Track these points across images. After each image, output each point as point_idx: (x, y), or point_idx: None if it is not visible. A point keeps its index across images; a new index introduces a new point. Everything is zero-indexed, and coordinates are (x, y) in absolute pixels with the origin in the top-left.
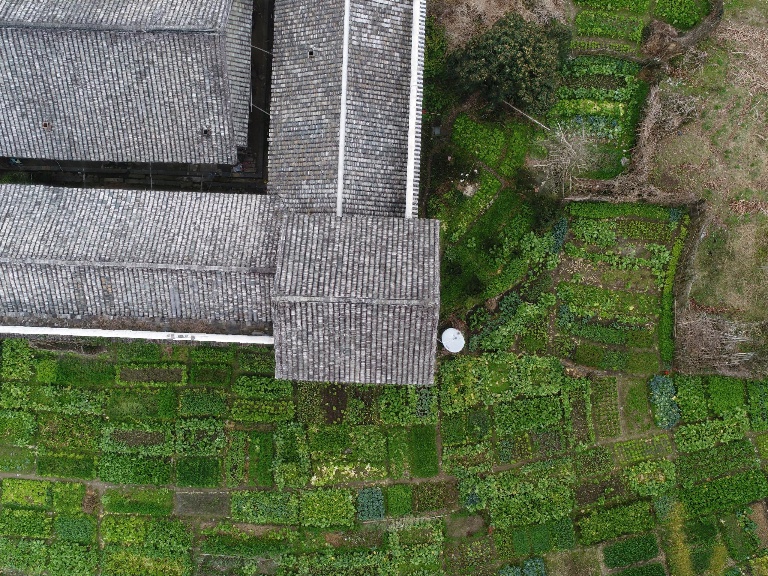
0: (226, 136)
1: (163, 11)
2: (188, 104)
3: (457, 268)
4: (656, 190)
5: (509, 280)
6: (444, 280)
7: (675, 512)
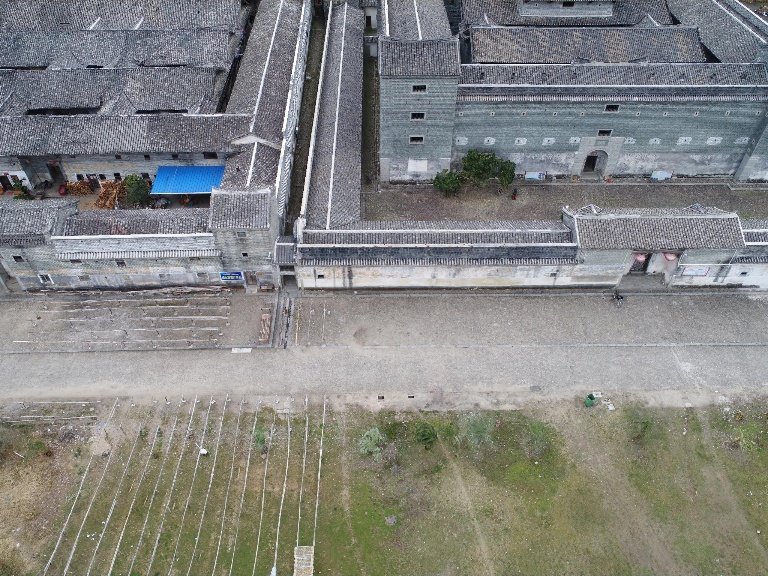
0: None
1: (28, 5)
2: None
3: None
4: None
5: None
6: None
7: None
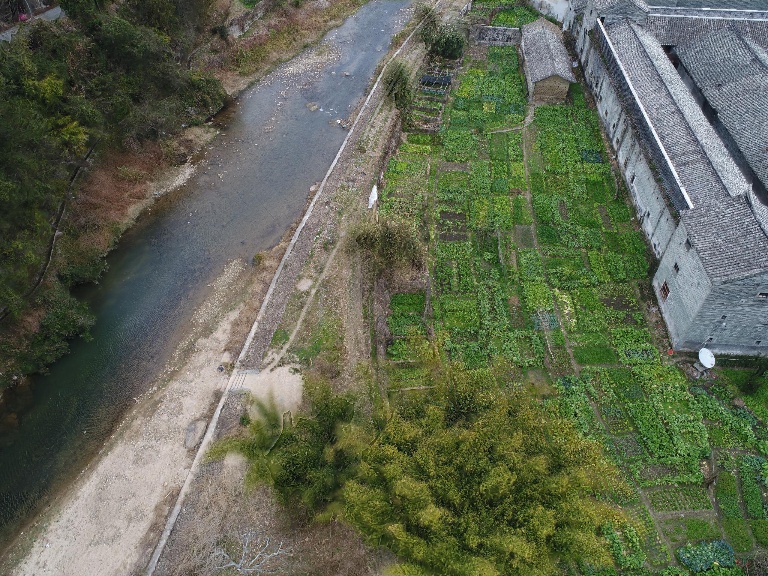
0: None
1: None
2: None
3: (766, 364)
4: None
5: (767, 416)
6: (742, 372)
7: (590, 567)
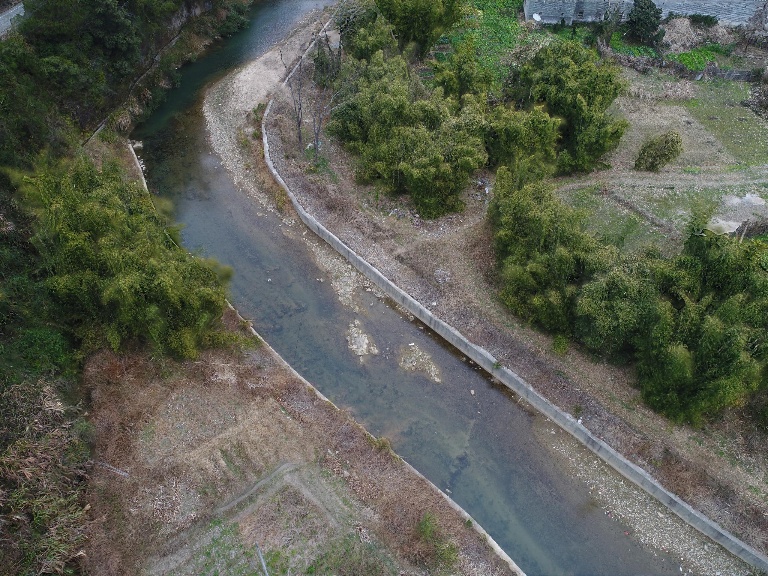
0: None
1: None
2: None
3: None
4: (609, 50)
5: None
6: None
7: None
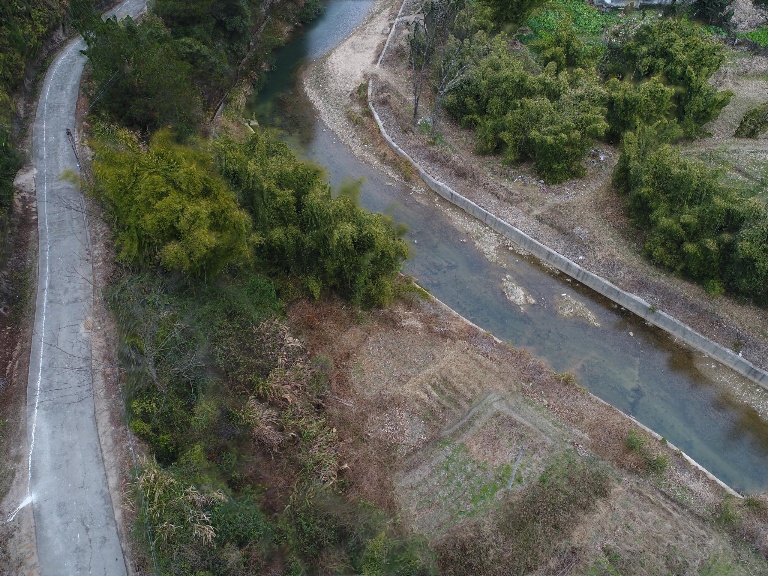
0: None
1: None
2: None
3: (633, 2)
4: None
5: None
6: None
7: None
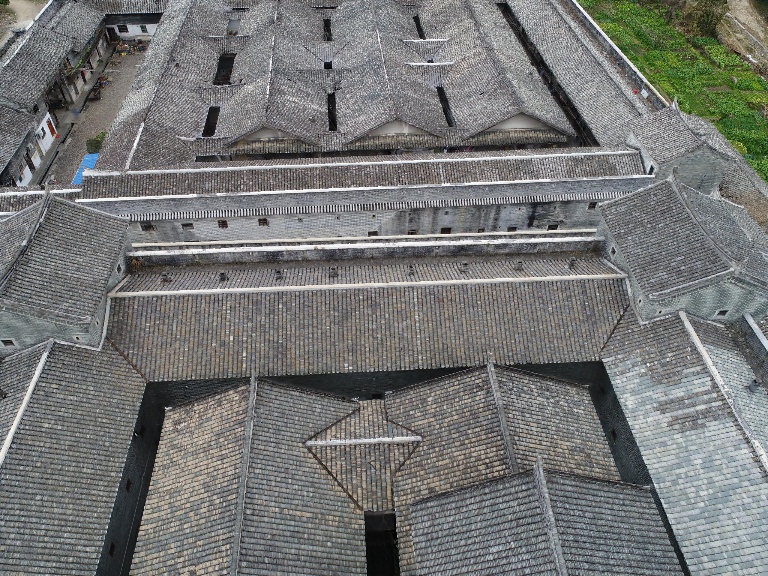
0: (488, 1)
1: None
2: (482, 1)
3: None
4: None
5: None
6: None
7: None
